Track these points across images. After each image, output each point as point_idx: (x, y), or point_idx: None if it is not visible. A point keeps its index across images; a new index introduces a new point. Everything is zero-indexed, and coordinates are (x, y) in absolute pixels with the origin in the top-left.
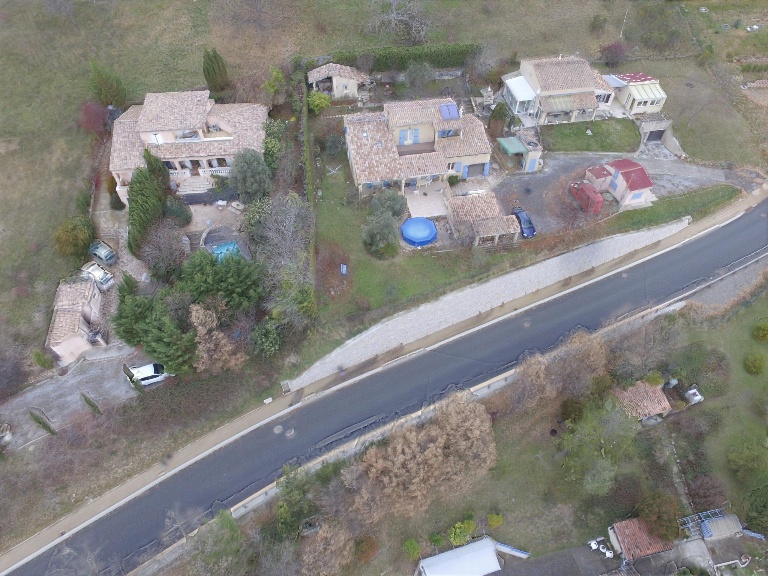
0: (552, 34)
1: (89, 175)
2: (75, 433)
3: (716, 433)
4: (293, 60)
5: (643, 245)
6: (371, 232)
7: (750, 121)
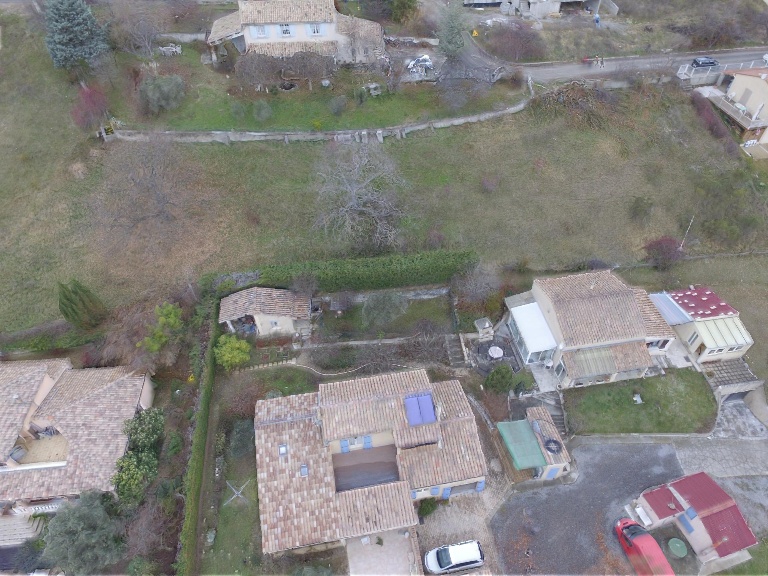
0: (576, 223)
1: None
2: None
3: None
4: (200, 282)
5: None
6: None
7: None
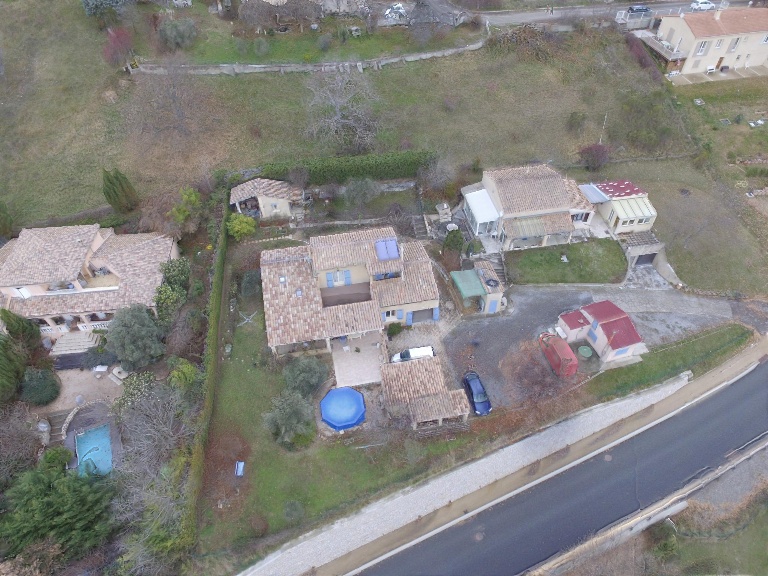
0: (522, 134)
1: None
2: None
3: None
4: (214, 175)
5: (632, 412)
6: (275, 420)
7: (759, 239)
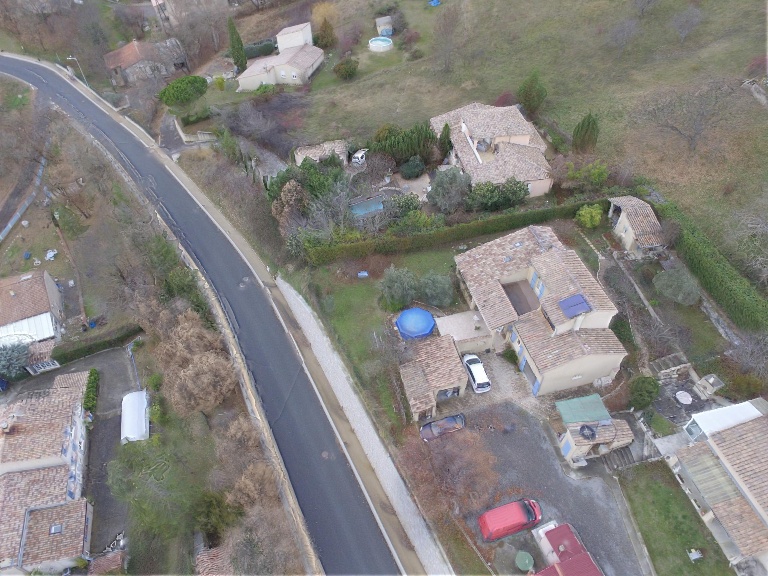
0: None
1: None
2: (244, 182)
3: None
4: (636, 177)
5: None
6: None
7: None
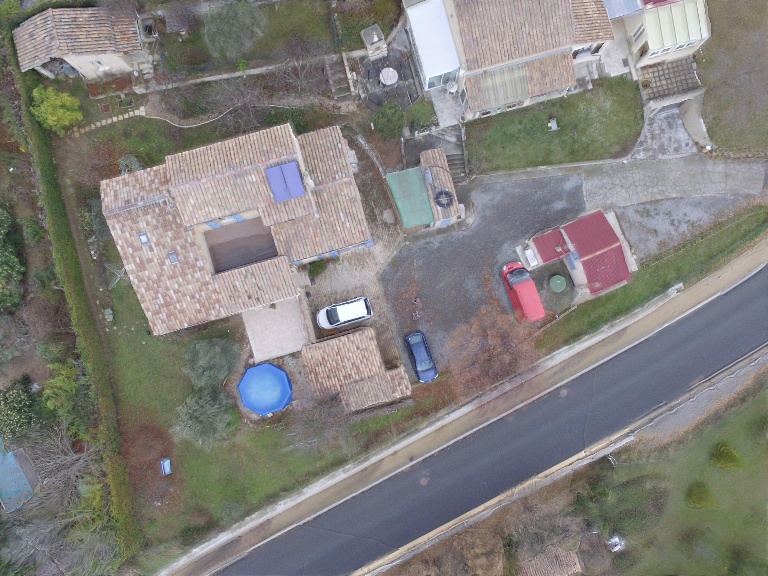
0: None
1: None
2: None
3: (628, 573)
4: None
5: (600, 339)
6: None
7: None
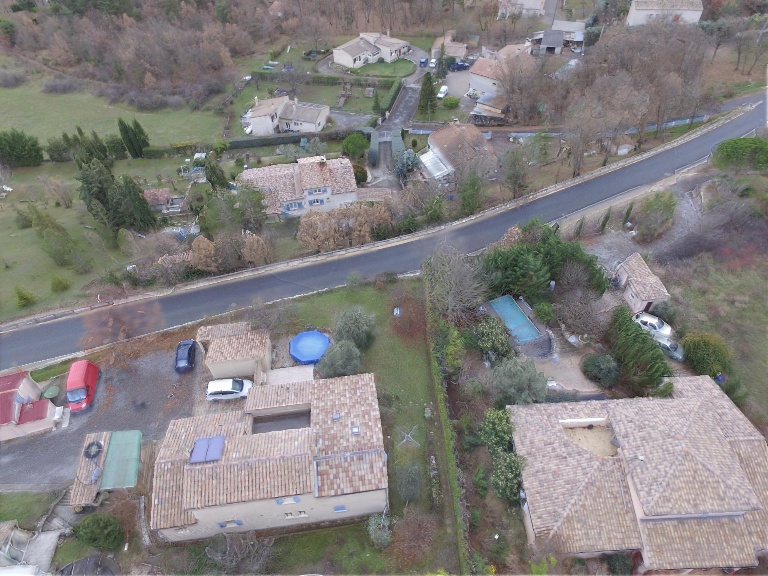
0: None
1: (767, 435)
2: None
3: None
4: None
5: None
6: None
7: None
